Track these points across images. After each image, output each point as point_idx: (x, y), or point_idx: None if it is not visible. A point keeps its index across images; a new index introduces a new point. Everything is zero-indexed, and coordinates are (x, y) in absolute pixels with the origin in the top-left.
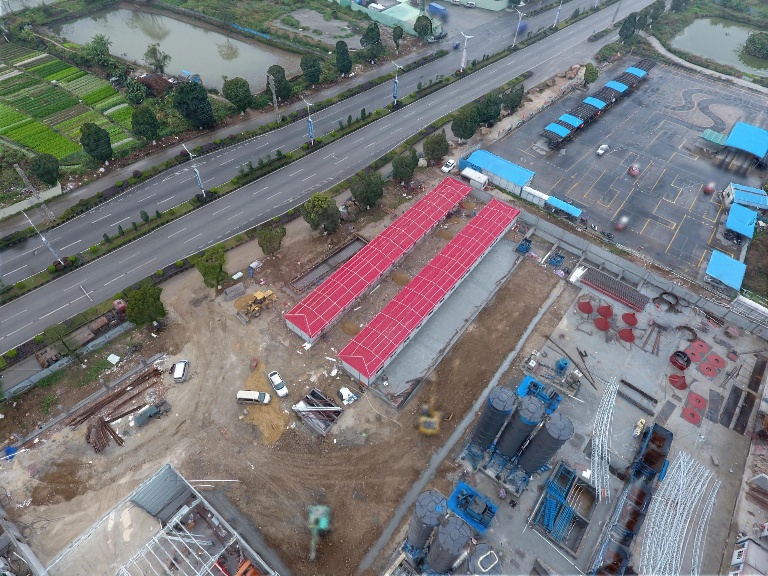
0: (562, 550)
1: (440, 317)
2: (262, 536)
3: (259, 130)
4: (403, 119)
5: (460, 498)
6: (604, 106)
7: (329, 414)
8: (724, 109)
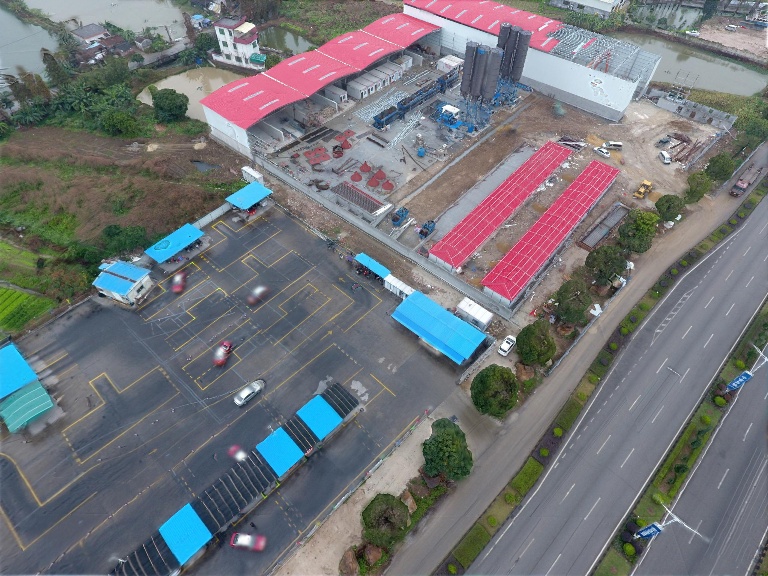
0: None
1: None
2: (577, 111)
3: None
4: (603, 486)
5: None
6: None
7: None
8: None
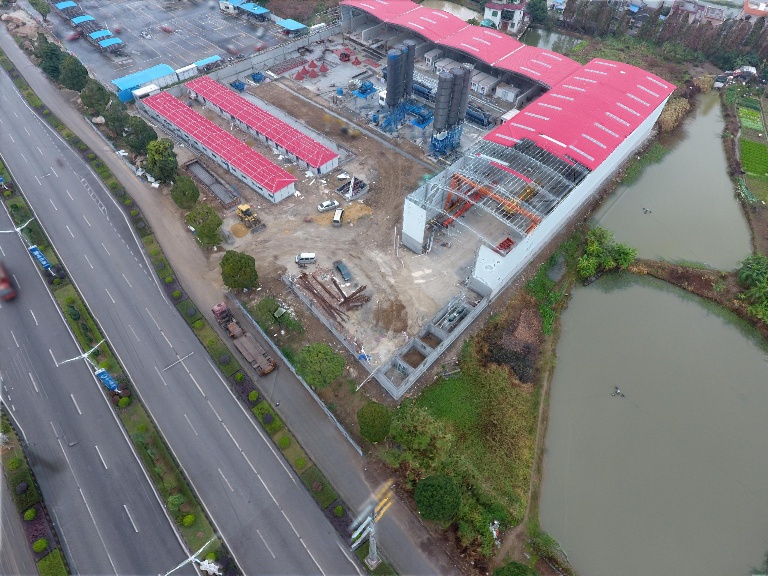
0: None
1: None
2: None
3: None
4: (6, 125)
5: (420, 119)
6: None
7: (356, 183)
8: None
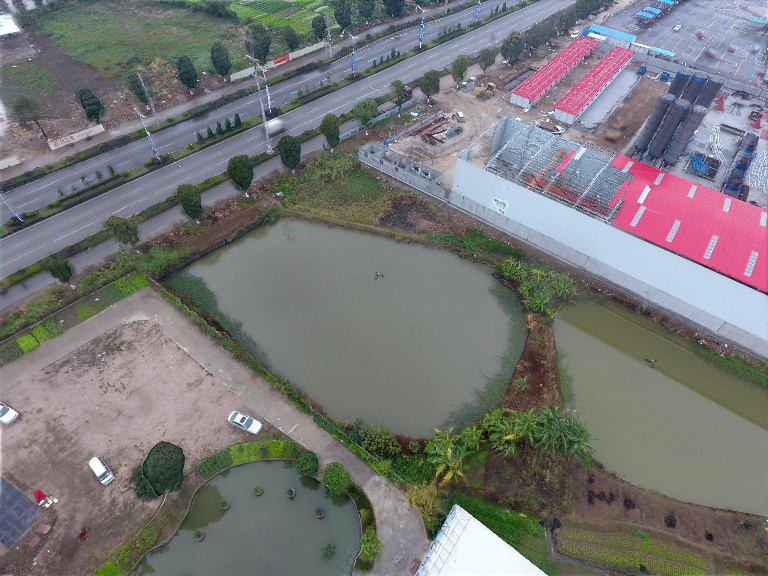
0: (706, 179)
1: (601, 100)
2: None
3: (434, 17)
4: (530, 12)
5: None
6: (672, 5)
7: None
8: (759, 8)
